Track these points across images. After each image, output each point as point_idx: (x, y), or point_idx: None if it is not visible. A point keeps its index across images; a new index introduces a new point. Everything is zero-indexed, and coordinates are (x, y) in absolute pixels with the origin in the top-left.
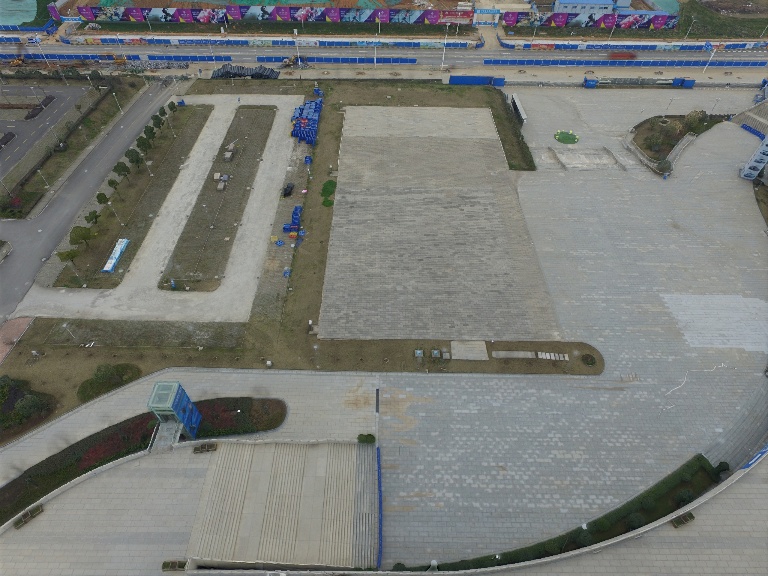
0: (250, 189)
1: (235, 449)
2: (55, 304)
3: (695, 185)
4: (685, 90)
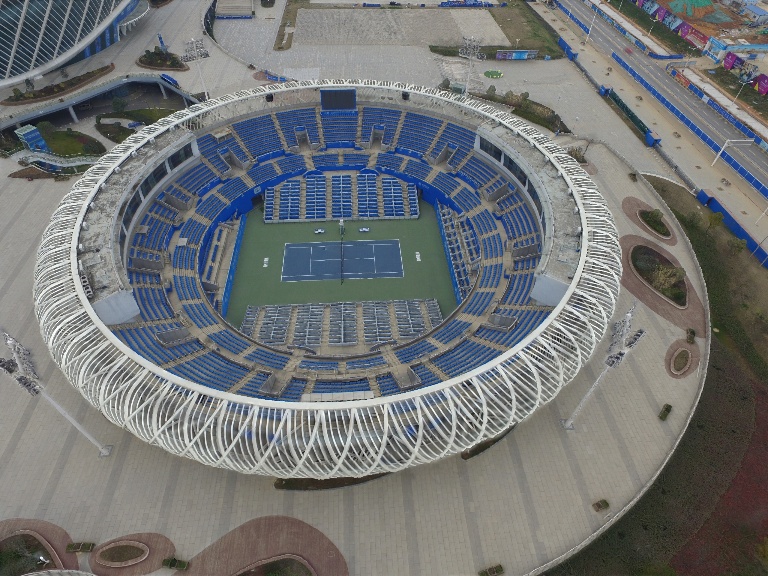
0: None
1: None
2: None
3: None
4: (639, 141)
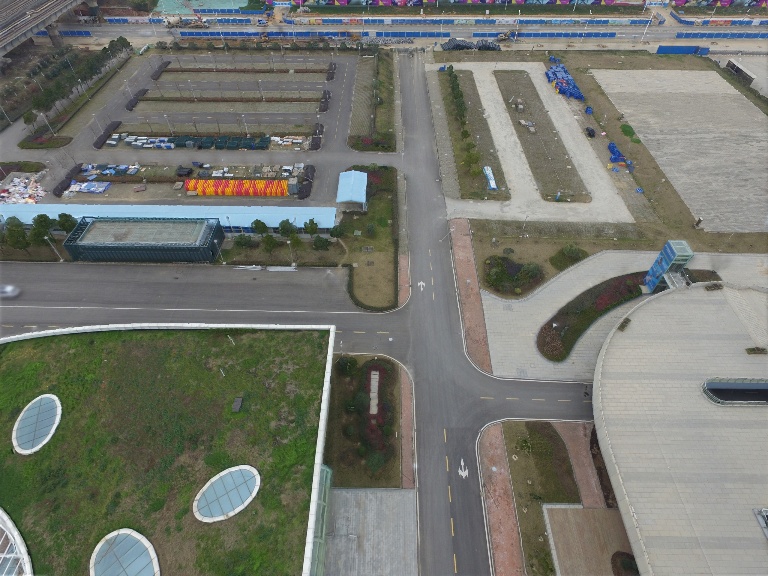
0: (557, 132)
1: (731, 290)
2: (474, 210)
3: None
4: None
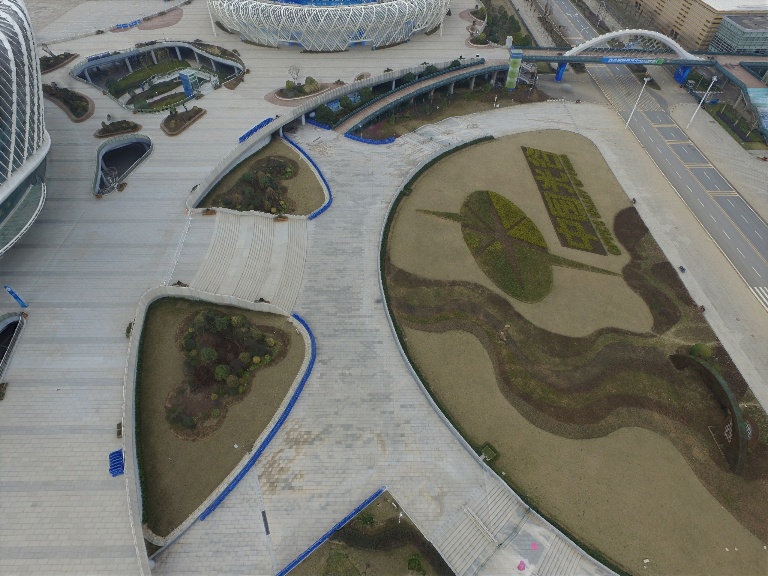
0: None
1: None
2: None
3: (178, 3)
4: None
